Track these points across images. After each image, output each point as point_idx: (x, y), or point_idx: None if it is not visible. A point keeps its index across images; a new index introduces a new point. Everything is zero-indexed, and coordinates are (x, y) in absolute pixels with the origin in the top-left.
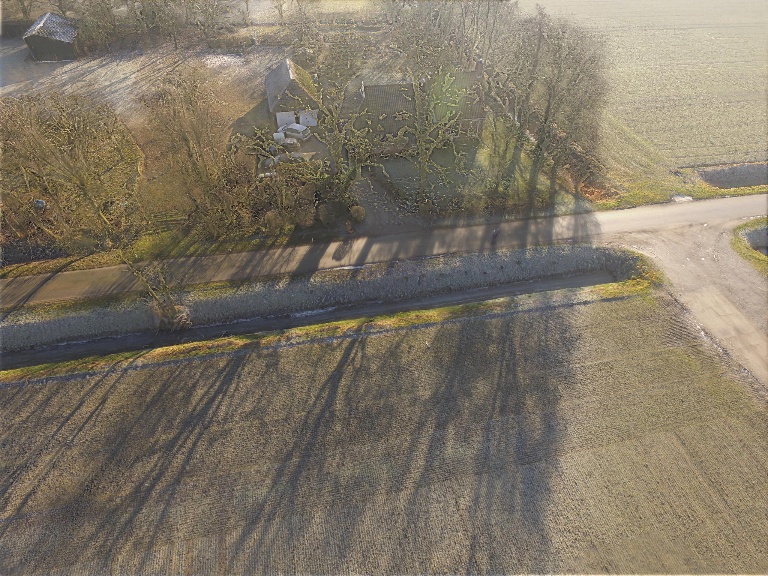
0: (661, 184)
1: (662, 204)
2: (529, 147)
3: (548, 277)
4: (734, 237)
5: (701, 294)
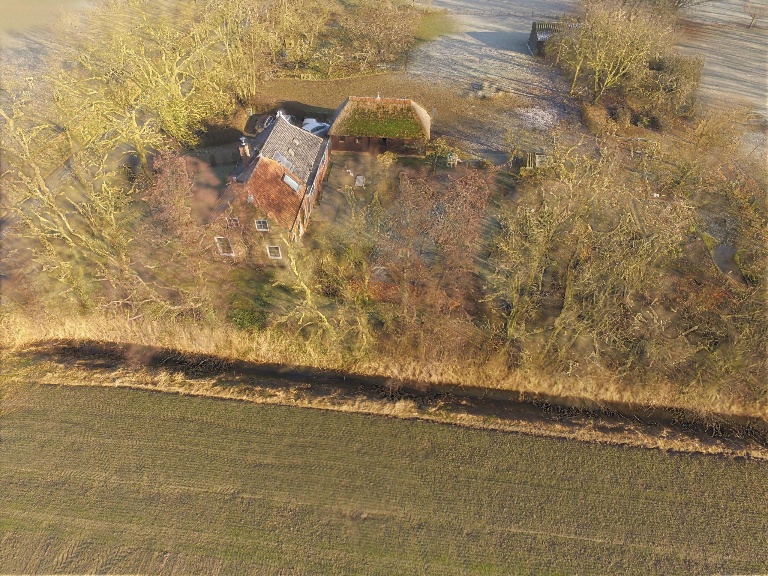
0: None
1: None
2: None
3: None
4: None
5: None
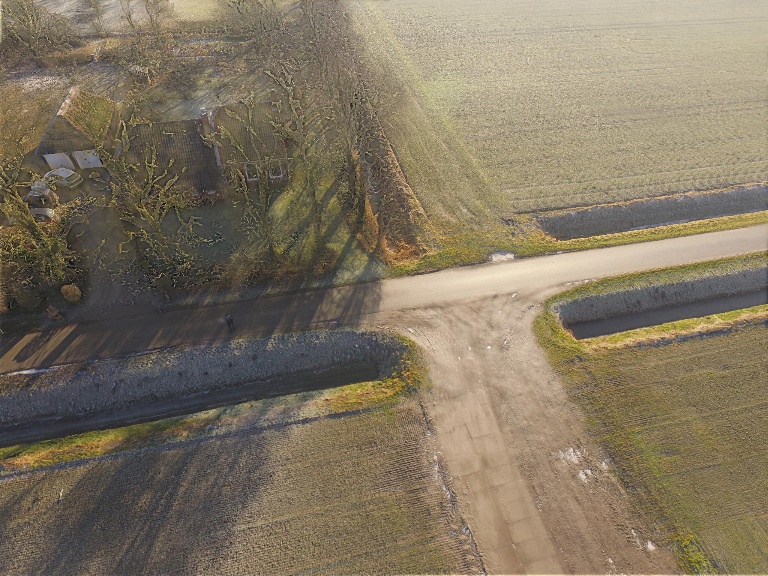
0: (482, 238)
1: (473, 266)
2: (344, 189)
3: (292, 374)
4: (542, 313)
5: (462, 403)
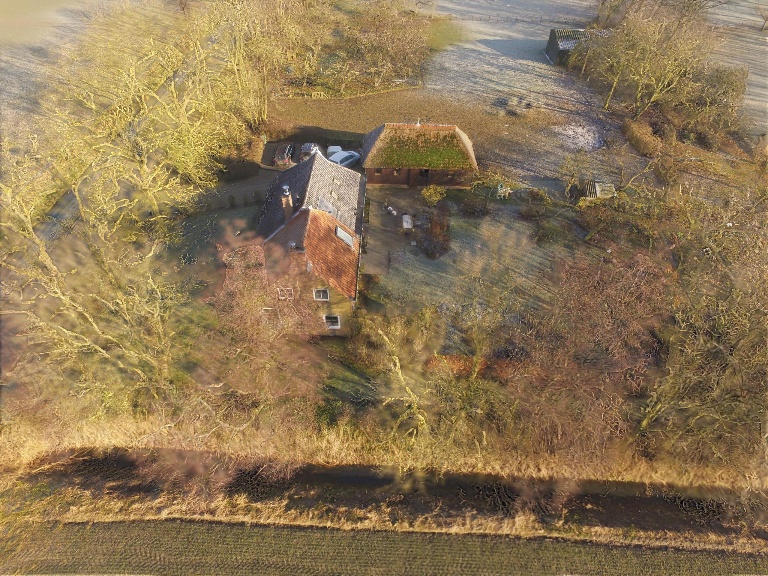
0: None
1: None
2: None
3: None
4: None
5: None
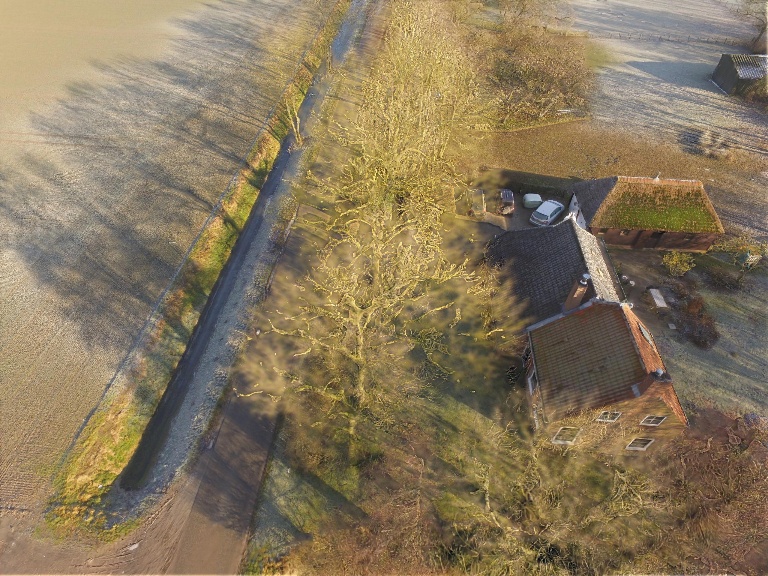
0: None
1: None
2: None
3: None
4: None
5: None
